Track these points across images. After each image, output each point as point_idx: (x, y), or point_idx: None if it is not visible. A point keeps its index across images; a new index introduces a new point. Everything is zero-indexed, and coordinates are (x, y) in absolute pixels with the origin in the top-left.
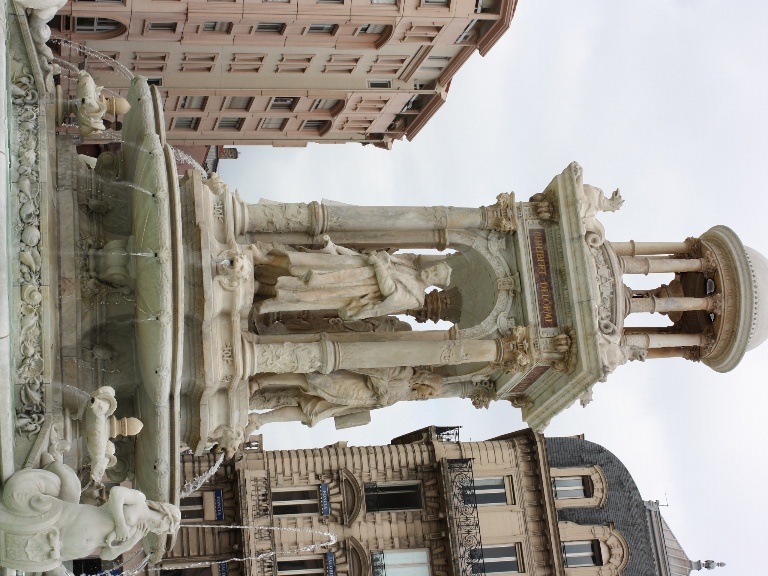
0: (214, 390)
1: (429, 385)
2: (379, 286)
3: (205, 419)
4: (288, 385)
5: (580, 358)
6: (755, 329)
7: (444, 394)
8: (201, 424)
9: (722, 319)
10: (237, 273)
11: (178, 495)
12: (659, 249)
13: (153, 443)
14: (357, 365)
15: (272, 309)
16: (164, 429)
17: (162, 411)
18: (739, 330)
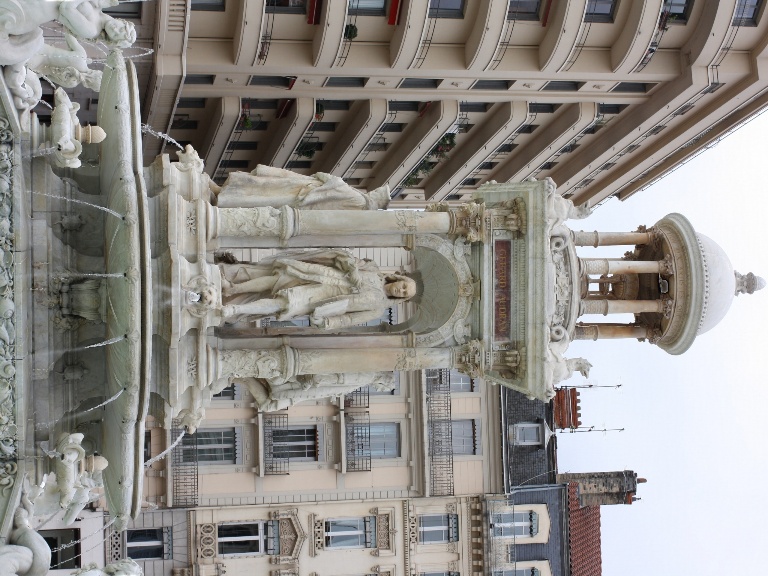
0: (182, 239)
1: (400, 279)
2: (323, 181)
3: (174, 245)
4: (267, 344)
5: (525, 194)
6: (703, 247)
7: (432, 353)
8: (171, 248)
9: (666, 240)
10: (190, 156)
11: (147, 212)
12: (596, 259)
13: (118, 175)
14: (316, 217)
15: (229, 198)
16: (128, 166)
17: (126, 162)
18: (685, 238)
